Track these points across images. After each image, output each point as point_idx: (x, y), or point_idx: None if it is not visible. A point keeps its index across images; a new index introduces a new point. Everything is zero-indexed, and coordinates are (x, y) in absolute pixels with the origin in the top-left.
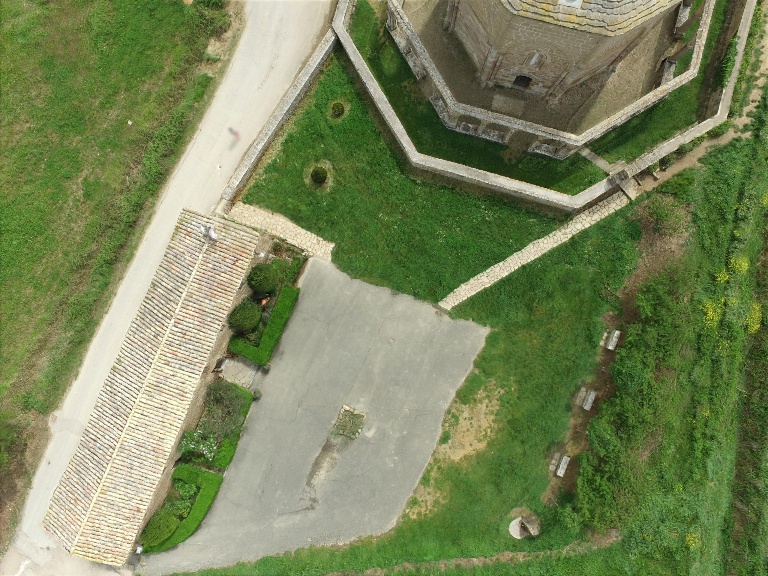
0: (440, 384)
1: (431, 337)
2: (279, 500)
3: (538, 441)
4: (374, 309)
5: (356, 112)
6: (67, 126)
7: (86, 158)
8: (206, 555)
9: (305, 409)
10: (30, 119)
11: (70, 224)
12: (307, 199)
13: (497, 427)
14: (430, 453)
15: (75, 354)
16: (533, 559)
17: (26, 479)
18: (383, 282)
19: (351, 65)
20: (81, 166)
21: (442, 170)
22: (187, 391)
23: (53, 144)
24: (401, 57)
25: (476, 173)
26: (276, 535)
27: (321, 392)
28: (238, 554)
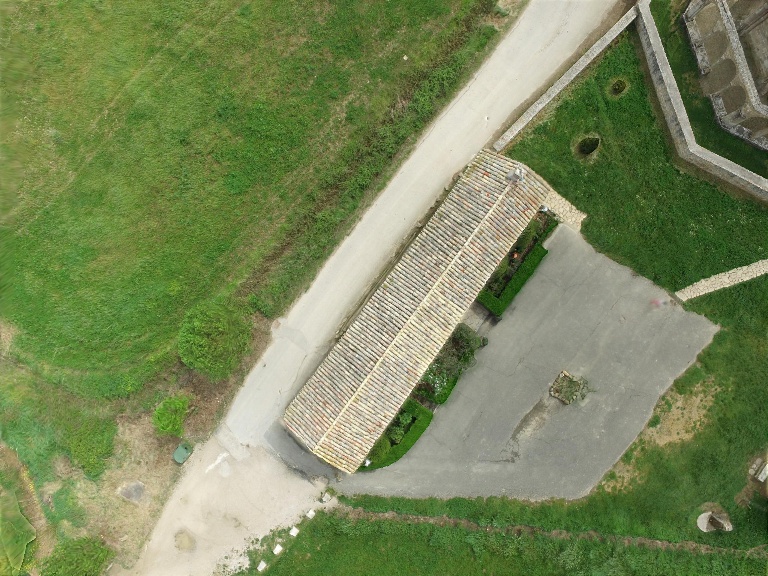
0: (661, 370)
1: (661, 323)
2: (482, 447)
3: (744, 443)
4: (612, 285)
5: (635, 93)
6: (343, 48)
7: (355, 83)
8: (401, 484)
9: (525, 366)
10: (308, 34)
11: (327, 143)
12: (570, 167)
13: (707, 422)
14: (637, 433)
15: (310, 268)
16: (716, 553)
17: (240, 376)
18: (626, 261)
19: (640, 47)
20: (349, 90)
21: (715, 166)
22: (451, 323)
23: (326, 63)
24: (689, 49)
25: (750, 175)
26: (472, 479)
27: (544, 353)
28: (432, 489)
